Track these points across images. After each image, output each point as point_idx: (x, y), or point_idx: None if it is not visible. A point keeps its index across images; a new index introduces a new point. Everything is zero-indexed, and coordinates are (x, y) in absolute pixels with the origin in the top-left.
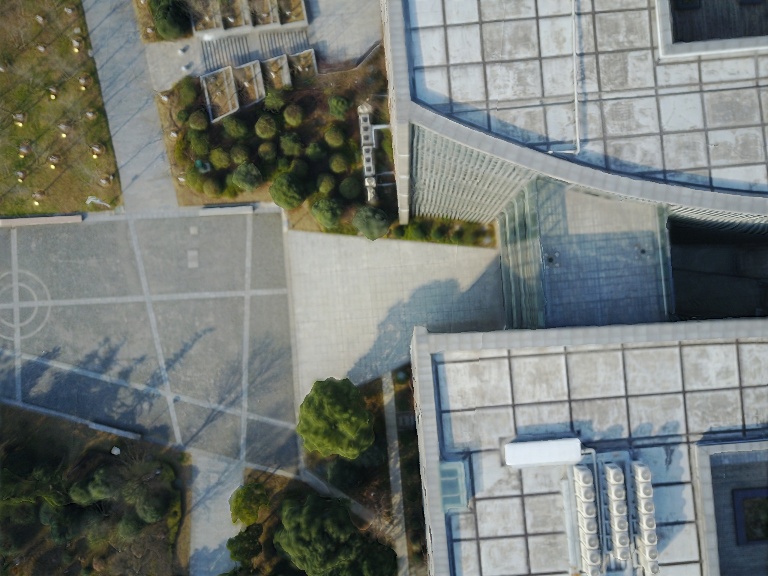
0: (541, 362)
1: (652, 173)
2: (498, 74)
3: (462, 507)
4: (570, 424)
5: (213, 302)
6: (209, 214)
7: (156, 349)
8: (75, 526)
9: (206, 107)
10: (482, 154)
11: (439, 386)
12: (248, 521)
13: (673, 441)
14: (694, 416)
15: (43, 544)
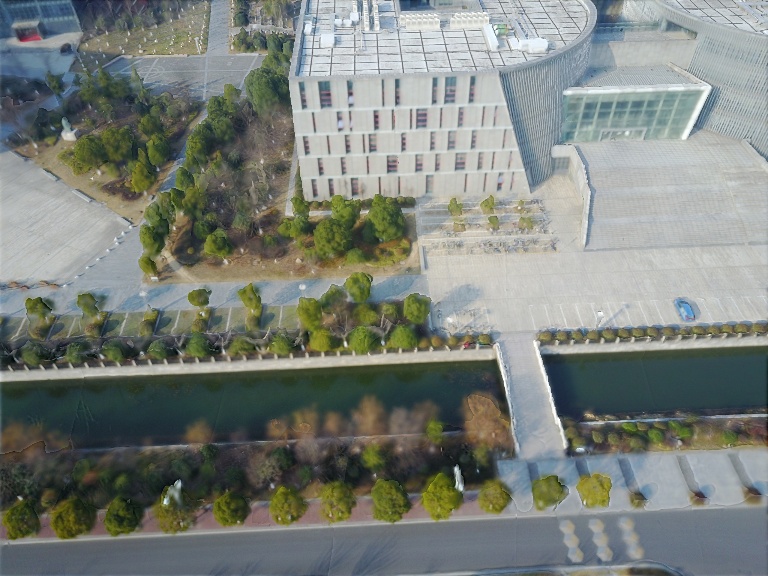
0: None
1: None
2: None
3: None
4: None
5: (234, 72)
6: (240, 55)
7: None
8: (147, 106)
9: None
10: None
11: None
12: (231, 88)
13: None
14: None
15: (126, 120)
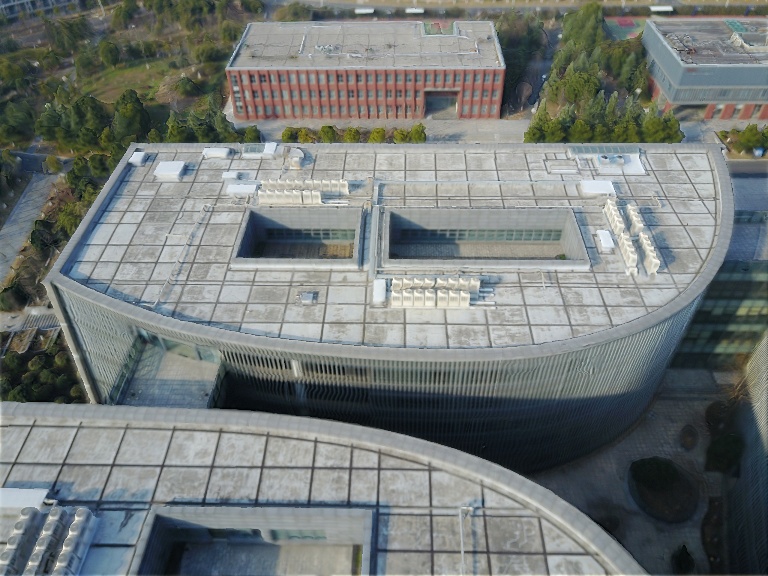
0: (57, 432)
1: (201, 322)
2: (126, 268)
3: None
4: (54, 483)
5: None
6: None
7: None
8: None
9: (4, 348)
10: (99, 311)
11: None
12: None
13: (137, 507)
14: (164, 486)
15: None
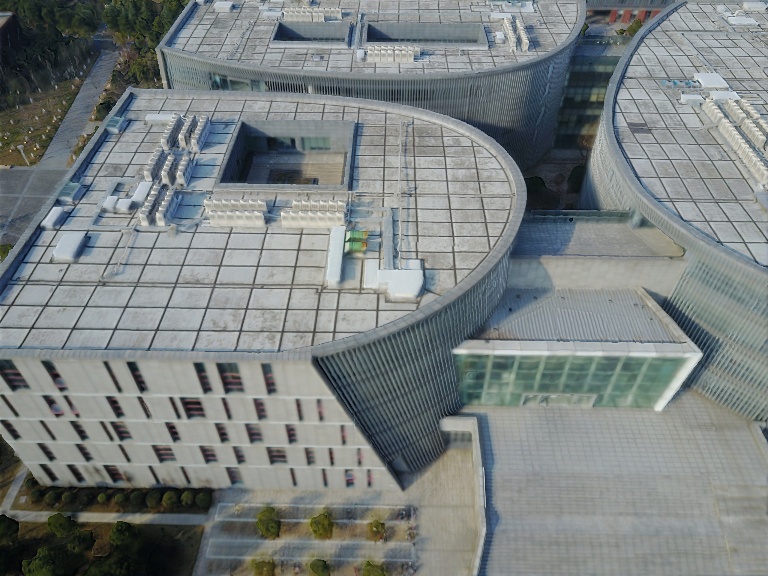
0: None
1: None
2: None
3: (115, 128)
4: (184, 116)
5: None
6: None
7: (11, 214)
8: None
9: None
10: (190, 66)
11: (130, 104)
12: None
13: None
14: None
15: None
